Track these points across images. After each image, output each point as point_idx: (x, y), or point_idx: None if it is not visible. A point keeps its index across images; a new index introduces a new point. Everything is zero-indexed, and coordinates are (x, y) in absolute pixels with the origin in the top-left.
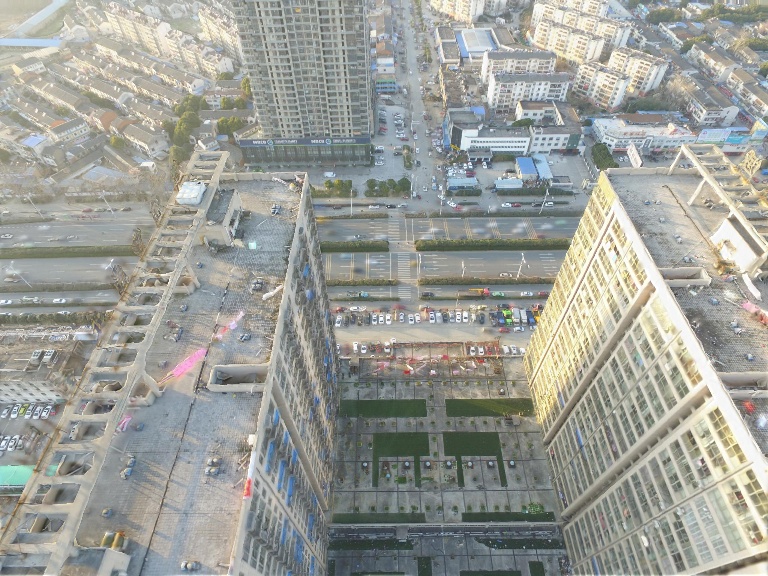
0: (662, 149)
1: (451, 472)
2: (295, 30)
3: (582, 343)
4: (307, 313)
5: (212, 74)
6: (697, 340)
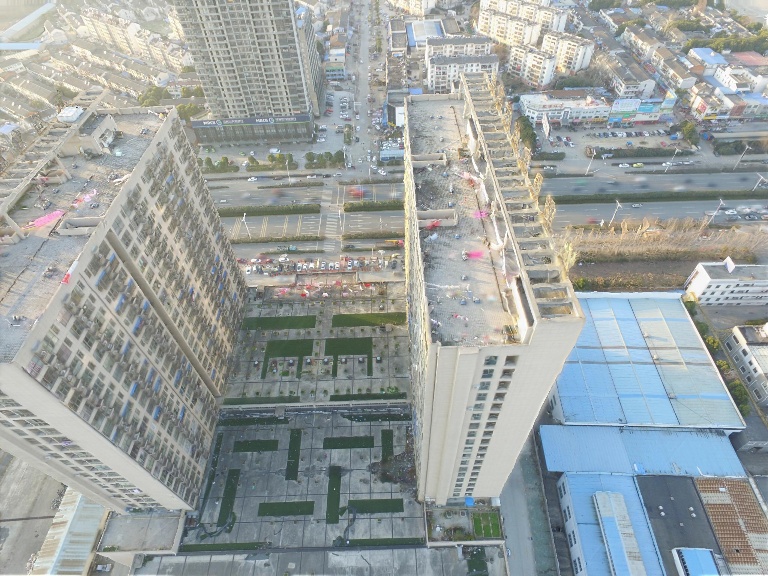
0: (581, 120)
1: (327, 367)
2: (230, 18)
3: None
4: (172, 212)
5: (178, 69)
6: (413, 194)
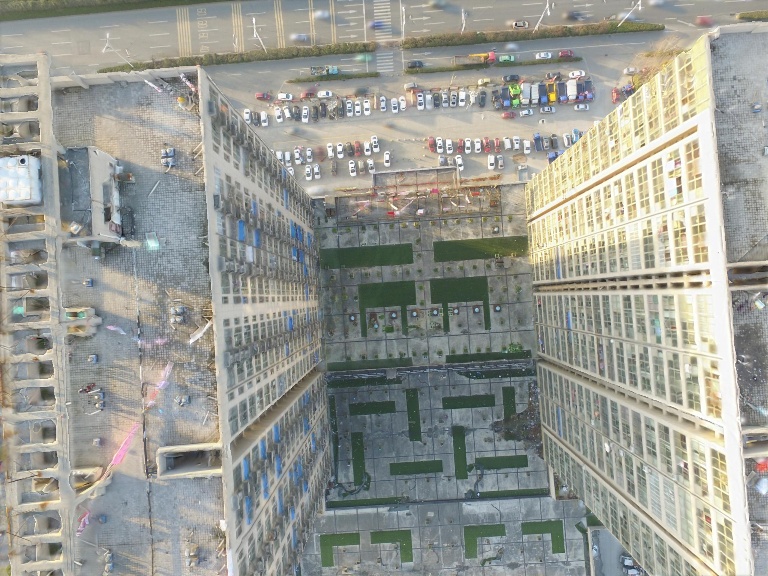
0: None
1: (437, 319)
2: None
3: (597, 243)
4: (256, 274)
5: None
6: (736, 389)
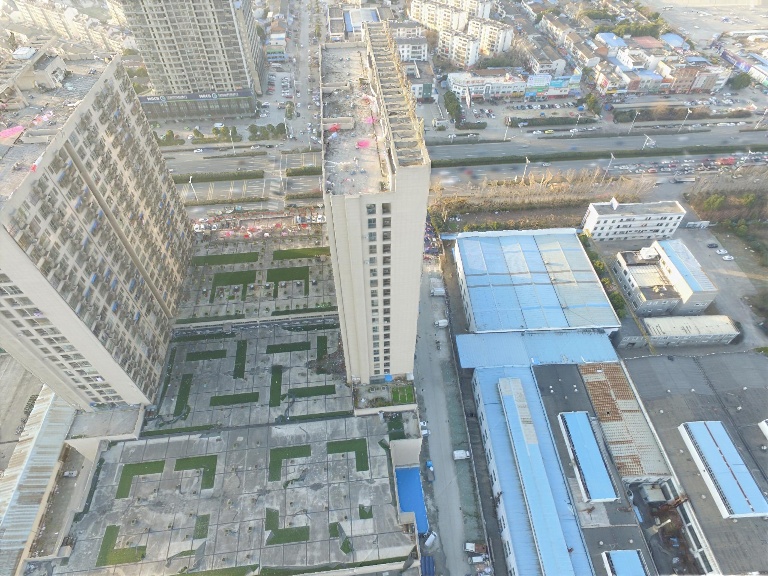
0: (501, 94)
1: (269, 291)
2: None
3: None
4: (121, 143)
5: None
6: None
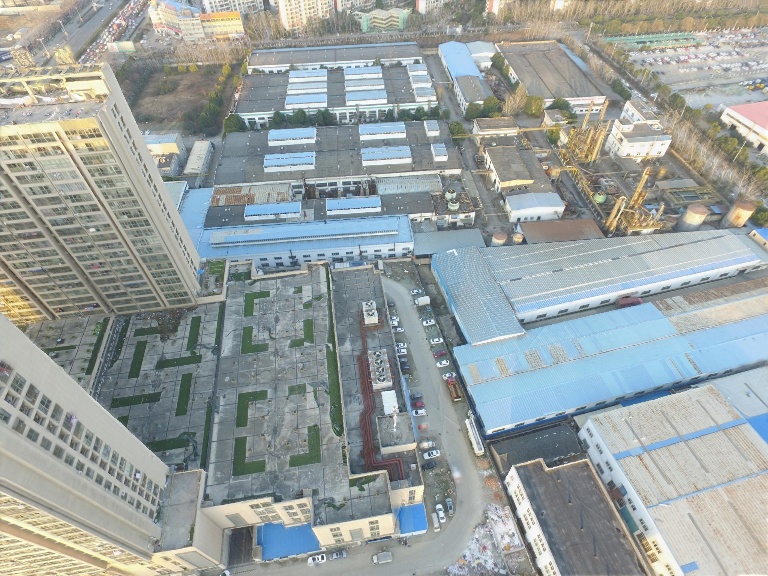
0: None
1: None
2: None
3: None
4: None
5: None
6: None
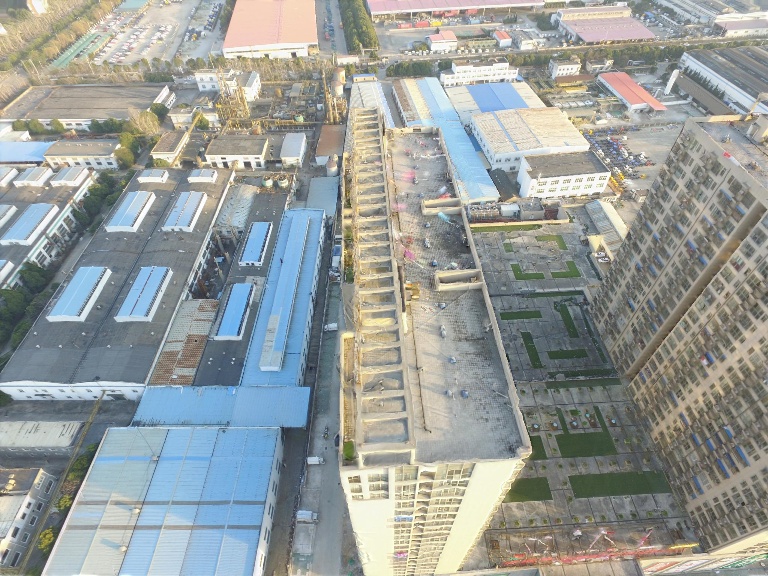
0: None
1: (532, 421)
2: None
3: None
4: None
5: None
6: None
